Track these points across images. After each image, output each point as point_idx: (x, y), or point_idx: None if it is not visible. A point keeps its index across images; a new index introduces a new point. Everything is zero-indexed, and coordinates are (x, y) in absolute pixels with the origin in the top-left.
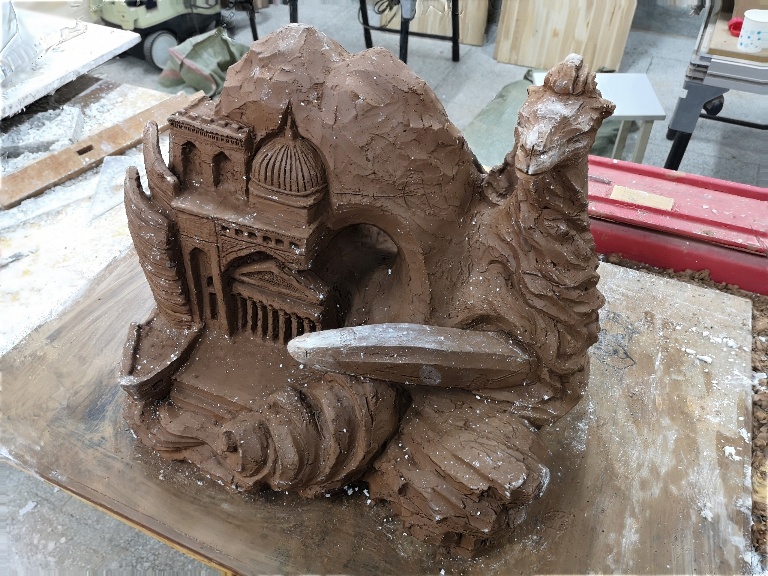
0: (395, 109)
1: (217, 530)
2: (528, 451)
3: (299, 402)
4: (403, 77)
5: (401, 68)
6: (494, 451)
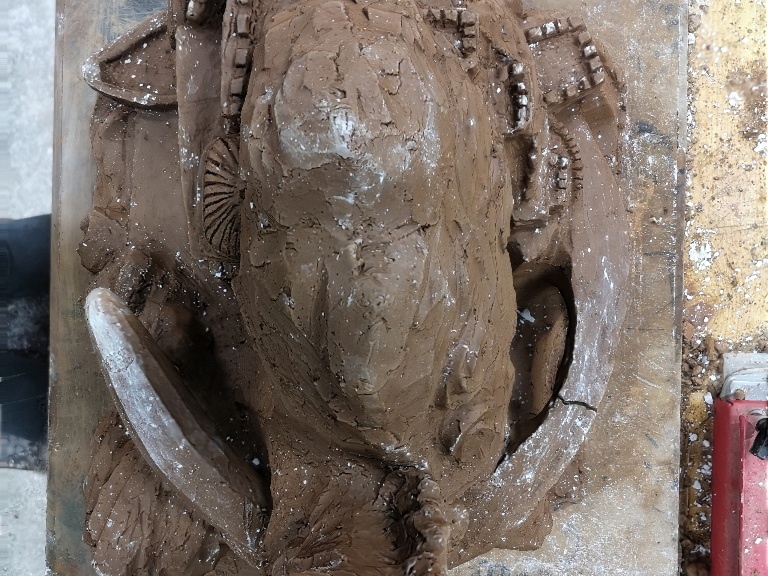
0: (314, 356)
1: (76, 231)
2: (159, 568)
3: (129, 294)
4: (347, 360)
5: (359, 352)
6: (133, 537)
